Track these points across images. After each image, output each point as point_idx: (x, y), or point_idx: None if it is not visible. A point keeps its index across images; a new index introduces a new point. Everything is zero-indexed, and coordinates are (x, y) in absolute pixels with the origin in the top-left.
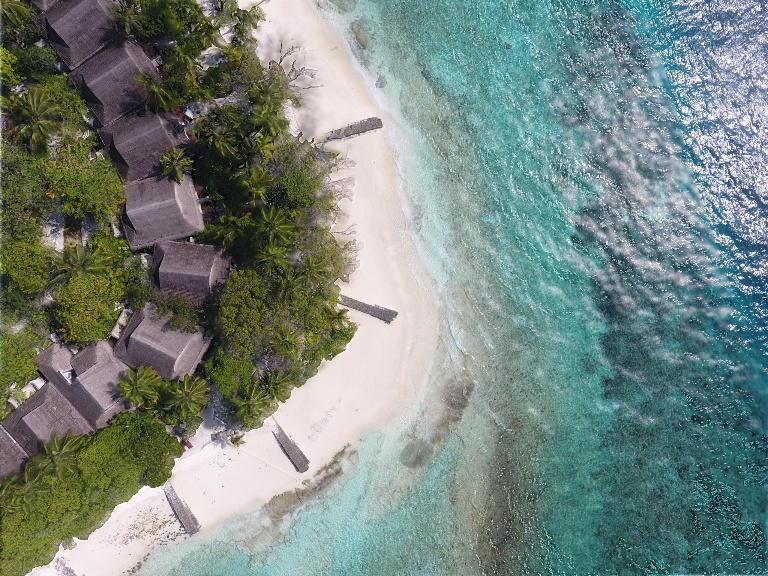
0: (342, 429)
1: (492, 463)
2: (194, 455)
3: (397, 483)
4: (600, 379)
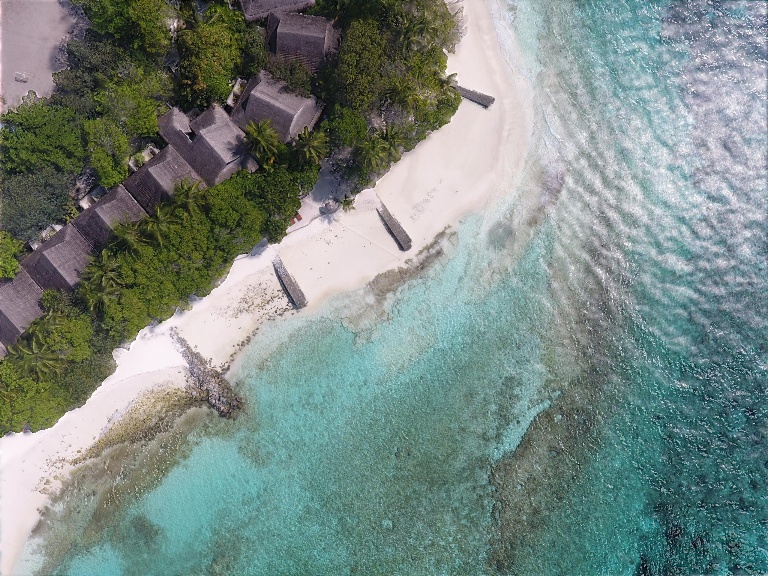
0: (443, 210)
1: (587, 247)
2: (302, 230)
3: (496, 264)
4: (689, 168)
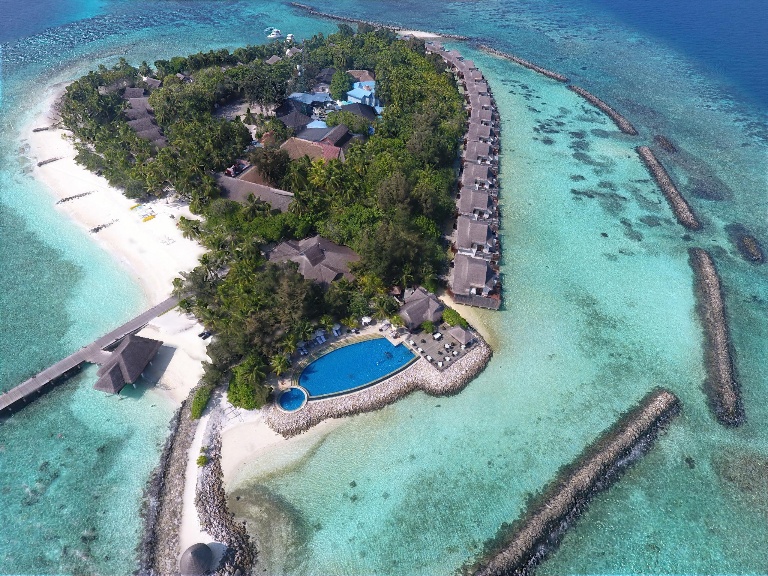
0: None
1: None
2: None
3: None
4: None
